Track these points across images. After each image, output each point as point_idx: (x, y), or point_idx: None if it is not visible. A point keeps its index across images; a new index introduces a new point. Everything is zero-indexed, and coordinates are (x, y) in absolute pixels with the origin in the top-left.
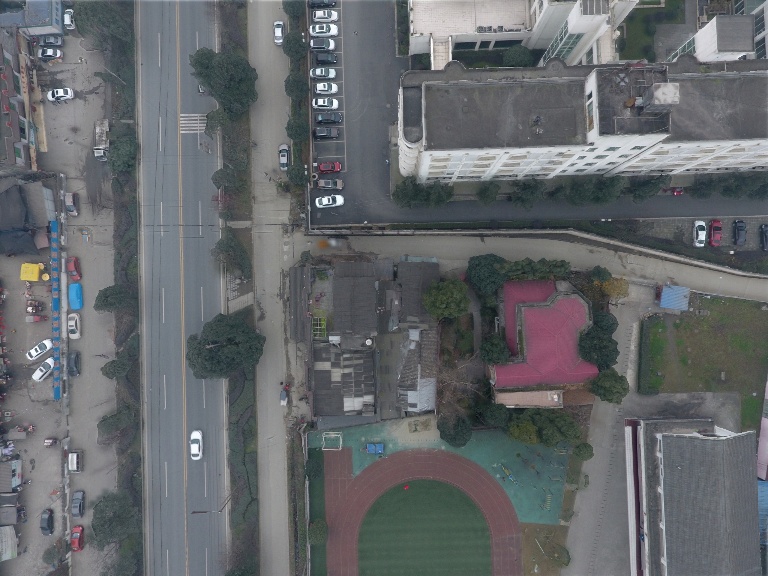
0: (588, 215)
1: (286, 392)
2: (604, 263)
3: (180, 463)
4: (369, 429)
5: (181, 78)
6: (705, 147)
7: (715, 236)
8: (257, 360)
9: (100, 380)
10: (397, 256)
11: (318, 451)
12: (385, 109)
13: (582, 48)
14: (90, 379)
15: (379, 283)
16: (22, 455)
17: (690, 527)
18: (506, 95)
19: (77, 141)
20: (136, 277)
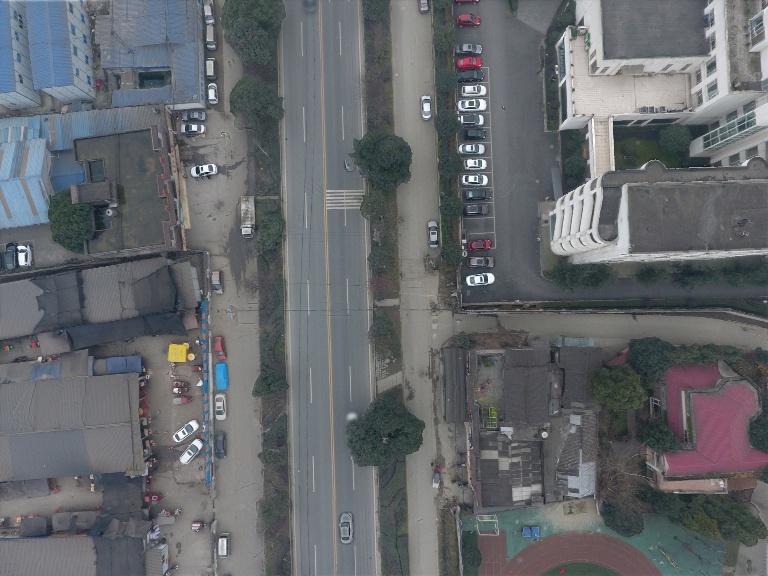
0: (742, 293)
1: (438, 474)
2: (758, 341)
3: (330, 546)
4: (523, 512)
5: (327, 153)
6: None
7: None
8: (418, 447)
9: (246, 461)
10: (548, 334)
11: (472, 534)
12: (534, 185)
13: (760, 136)
14: (236, 460)
15: None
16: (168, 539)
17: None
18: (707, 195)
19: (220, 217)
20: (283, 357)
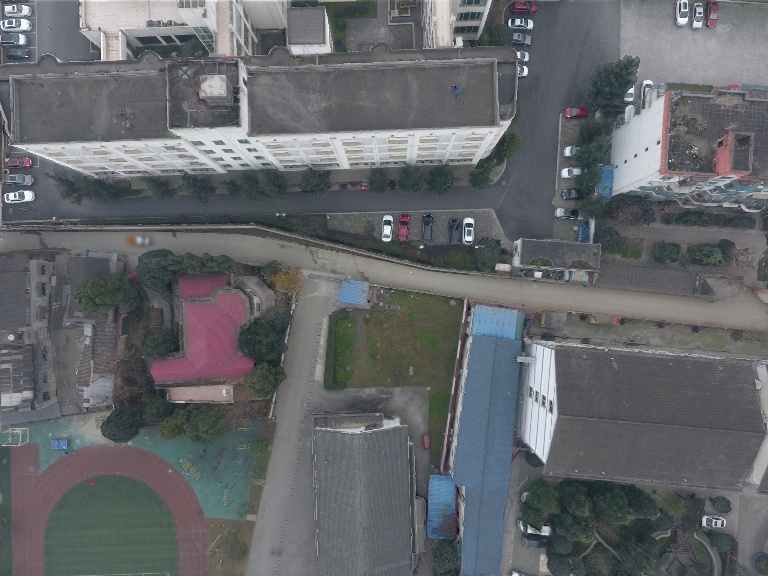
0: (278, 210)
1: None
2: (295, 258)
3: None
4: (56, 425)
5: None
6: (306, 140)
7: (400, 230)
8: None
9: None
10: None
11: (4, 447)
12: None
13: None
14: None
15: (57, 278)
16: None
17: (334, 521)
18: (101, 88)
19: None
20: None
